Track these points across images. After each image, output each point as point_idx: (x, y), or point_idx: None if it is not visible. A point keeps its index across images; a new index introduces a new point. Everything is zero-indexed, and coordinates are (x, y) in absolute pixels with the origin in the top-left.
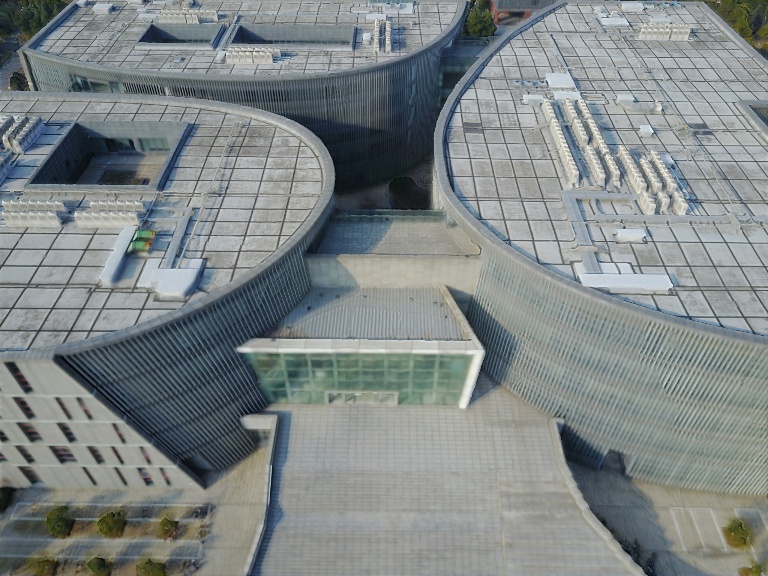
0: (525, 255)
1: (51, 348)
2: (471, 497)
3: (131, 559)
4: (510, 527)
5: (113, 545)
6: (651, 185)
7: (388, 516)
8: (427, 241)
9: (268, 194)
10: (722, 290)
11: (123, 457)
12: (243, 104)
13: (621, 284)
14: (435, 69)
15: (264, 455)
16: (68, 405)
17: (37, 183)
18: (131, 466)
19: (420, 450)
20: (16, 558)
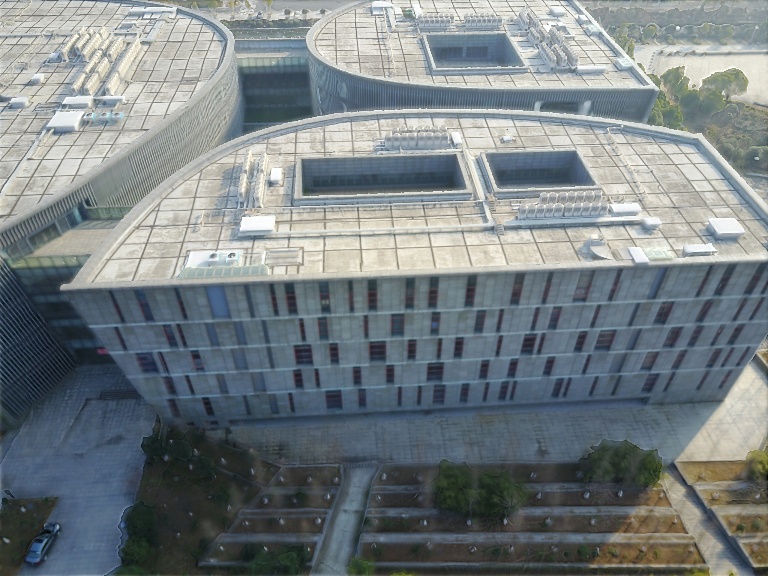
0: (198, 20)
1: None
2: None
3: None
4: None
5: None
6: None
7: None
8: None
9: None
10: (104, 14)
11: None
12: None
13: (157, 8)
14: None
15: None
16: None
17: None
18: None
19: None
20: None
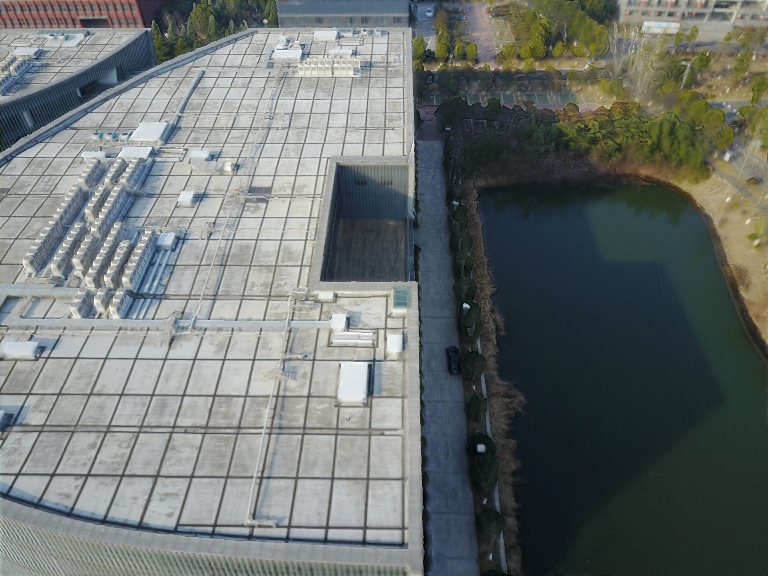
0: None
1: None
2: None
3: None
4: None
5: None
6: (103, 278)
7: None
8: None
9: None
10: (66, 431)
11: None
12: None
13: None
14: None
15: None
16: None
17: None
18: None
19: None
20: None
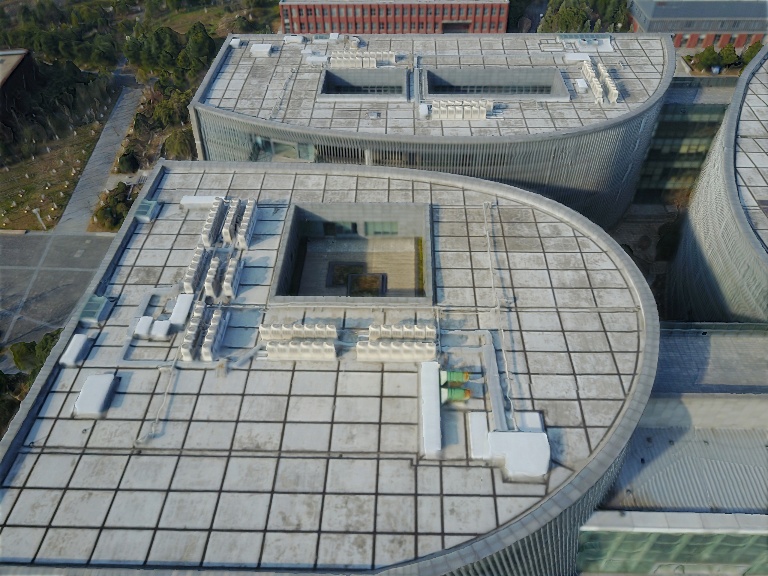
0: None
1: (412, 570)
2: None
3: None
4: None
5: None
6: None
7: None
8: (767, 365)
9: (570, 308)
10: None
11: None
12: (456, 169)
13: None
14: (655, 119)
15: None
16: None
17: (278, 291)
18: None
19: None
20: None
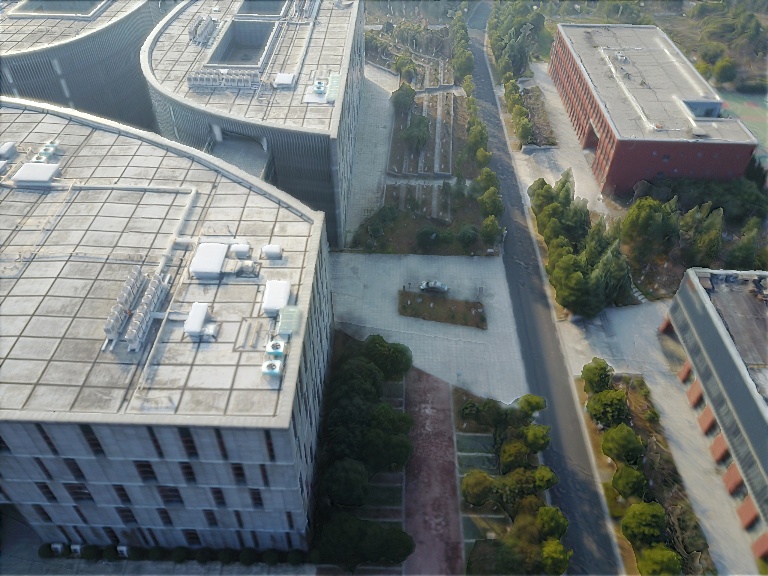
0: None
1: None
2: None
3: None
4: None
5: None
6: None
7: None
8: None
9: None
10: None
11: None
12: None
13: None
14: (204, 138)
15: None
16: None
17: None
18: None
19: None
20: None
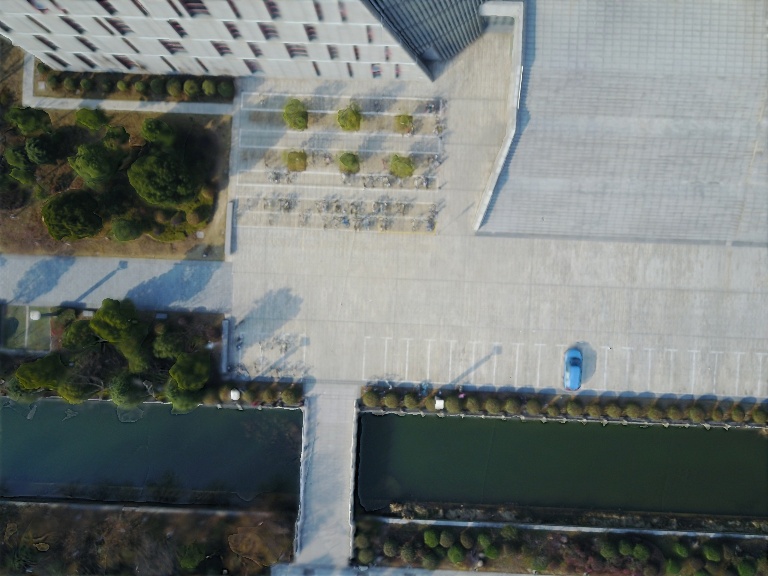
0: None
1: None
2: (732, 104)
3: (374, 153)
4: (766, 137)
5: (353, 139)
6: None
7: (640, 122)
8: None
9: None
10: None
11: (361, 54)
12: None
13: None
14: None
15: (491, 42)
16: (324, 7)
17: None
18: (366, 62)
19: (686, 49)
20: (263, 149)
